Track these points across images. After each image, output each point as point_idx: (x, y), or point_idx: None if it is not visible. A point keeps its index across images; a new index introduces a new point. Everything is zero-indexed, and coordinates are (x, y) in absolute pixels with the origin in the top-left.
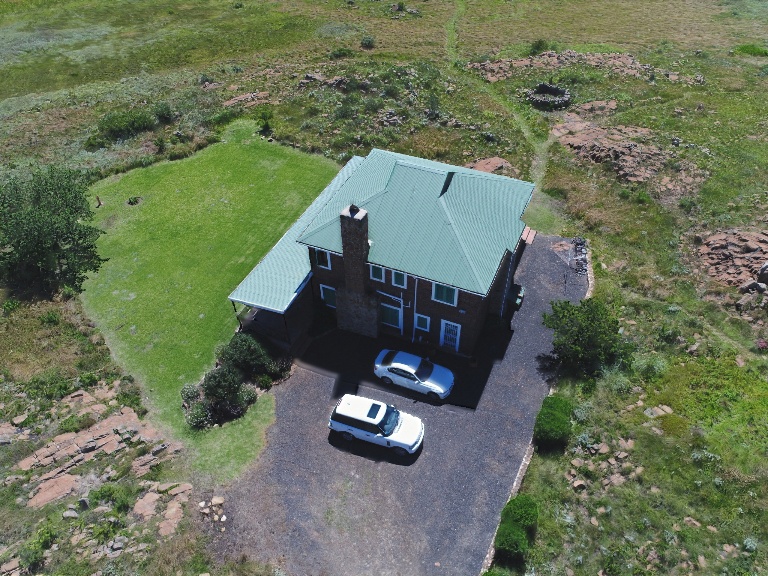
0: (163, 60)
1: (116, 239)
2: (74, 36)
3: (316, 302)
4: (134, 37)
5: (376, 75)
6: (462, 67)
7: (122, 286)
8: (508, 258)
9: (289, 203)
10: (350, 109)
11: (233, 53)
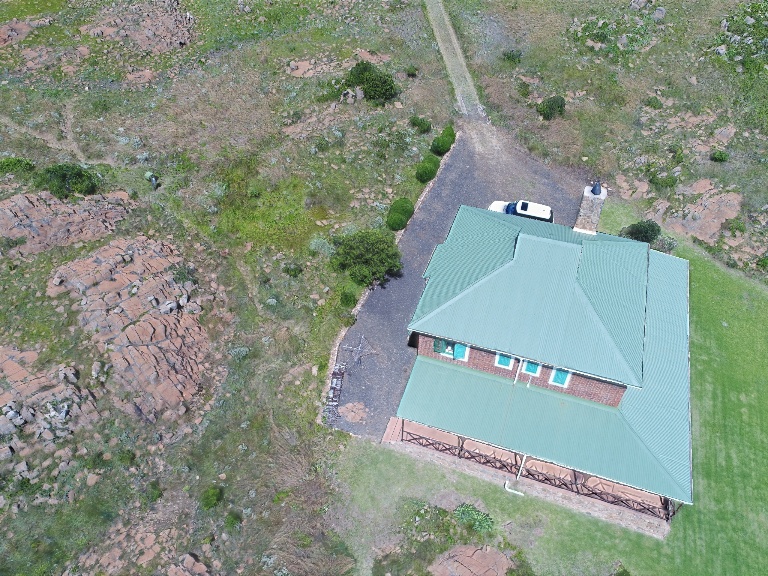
0: None
1: None
2: None
3: None
4: None
5: None
6: None
7: None
8: None
9: (763, 518)
10: None
11: None
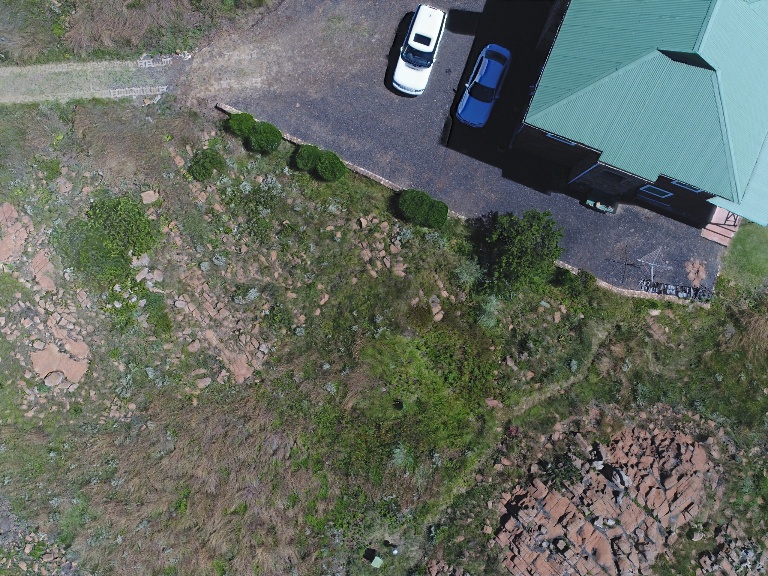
0: None
1: None
2: None
3: None
4: None
5: None
6: None
7: None
8: None
9: None
10: None
11: None
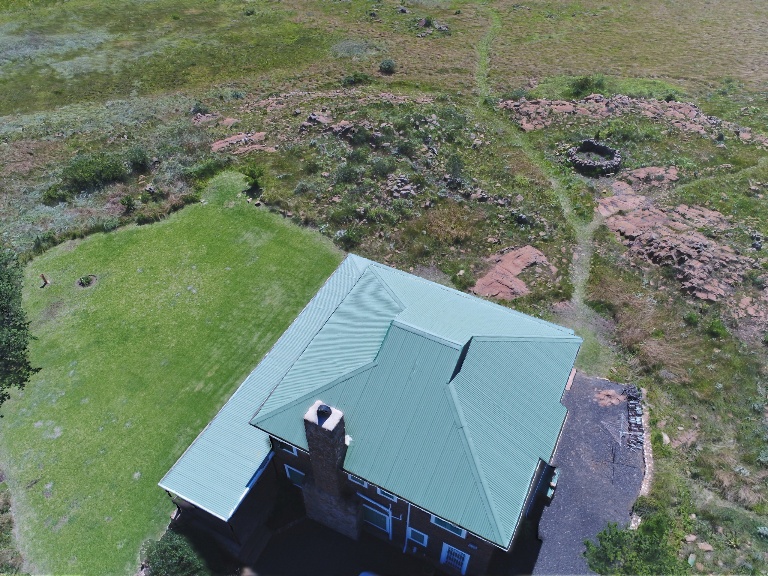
0: (158, 78)
1: (55, 338)
2: (66, 43)
3: (280, 480)
4: (131, 47)
5: (390, 124)
6: (493, 105)
7: (48, 415)
8: (541, 466)
9: (269, 301)
10: (354, 171)
11: (236, 72)
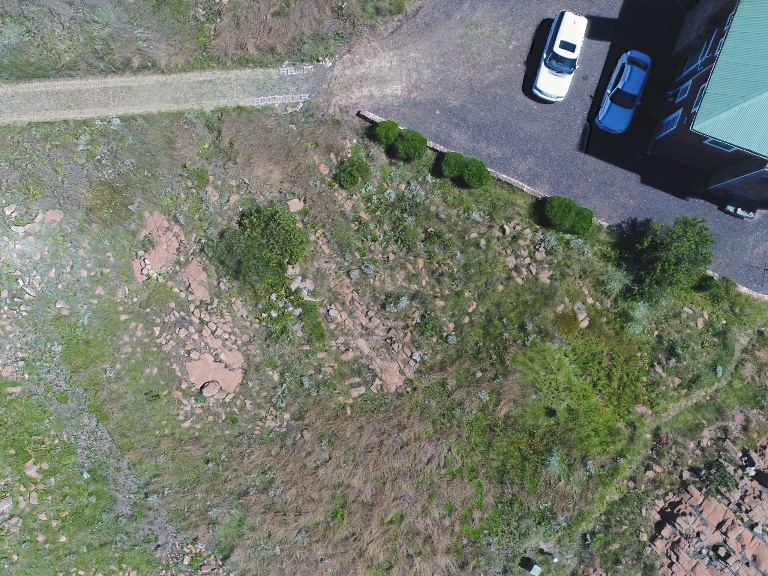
0: None
1: None
2: None
3: None
4: None
5: None
6: None
7: None
8: (762, 165)
9: None
10: None
11: None
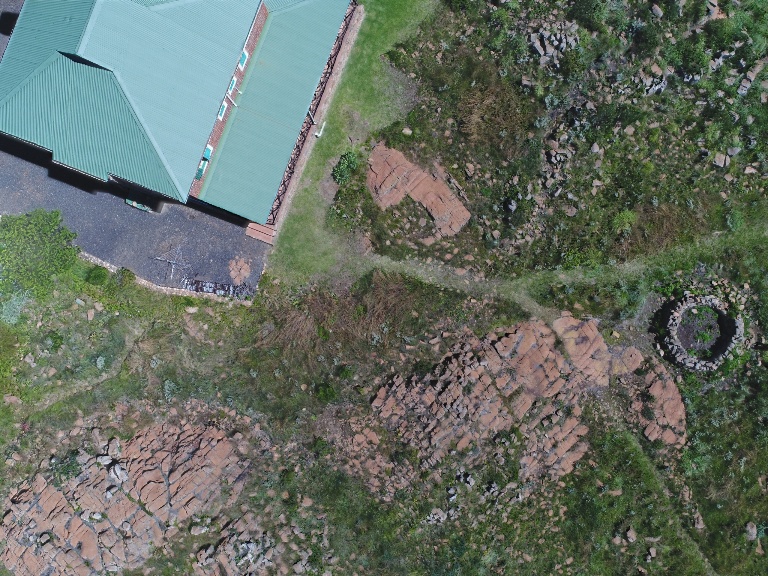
0: None
1: None
2: None
3: None
4: None
5: None
6: None
7: None
8: None
9: None
10: None
11: None
